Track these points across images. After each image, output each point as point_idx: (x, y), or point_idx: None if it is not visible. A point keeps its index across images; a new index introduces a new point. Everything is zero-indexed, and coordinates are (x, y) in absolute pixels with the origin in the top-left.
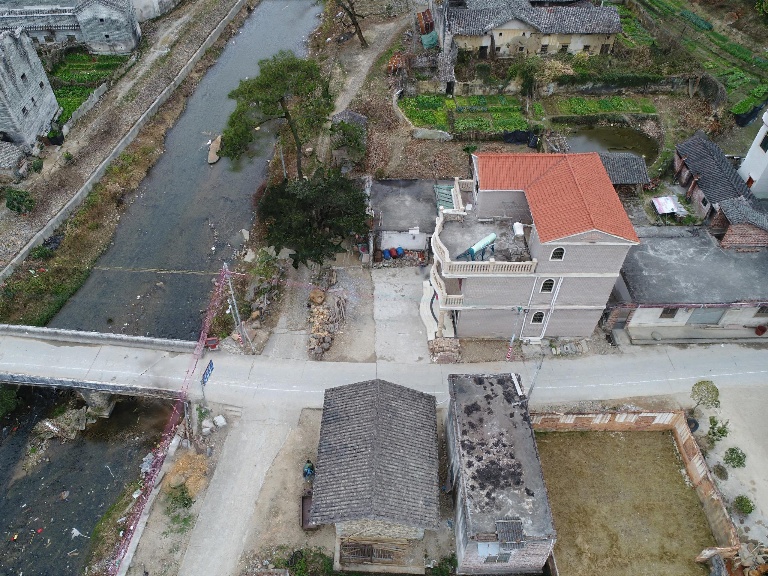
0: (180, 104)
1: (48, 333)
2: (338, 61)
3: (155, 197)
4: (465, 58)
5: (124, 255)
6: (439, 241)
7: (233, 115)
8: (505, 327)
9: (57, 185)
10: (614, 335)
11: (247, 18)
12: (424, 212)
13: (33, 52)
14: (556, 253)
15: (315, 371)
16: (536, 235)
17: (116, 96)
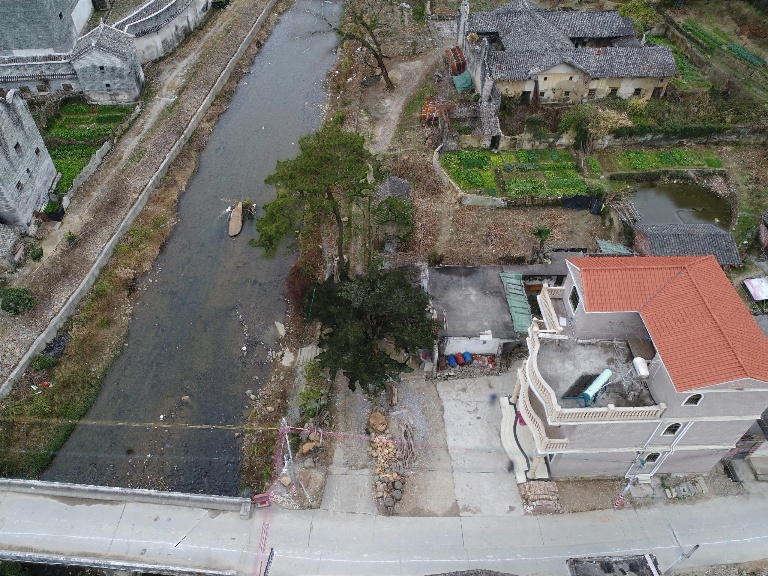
0: (192, 161)
1: (59, 488)
2: (364, 107)
3: (172, 281)
4: (507, 105)
5: (141, 359)
6: (541, 378)
7: (273, 208)
8: (610, 466)
9: (59, 274)
10: (734, 468)
11: (257, 54)
12: (494, 310)
13: (27, 115)
14: (691, 399)
15: (388, 531)
16: (662, 373)
17: (121, 156)
